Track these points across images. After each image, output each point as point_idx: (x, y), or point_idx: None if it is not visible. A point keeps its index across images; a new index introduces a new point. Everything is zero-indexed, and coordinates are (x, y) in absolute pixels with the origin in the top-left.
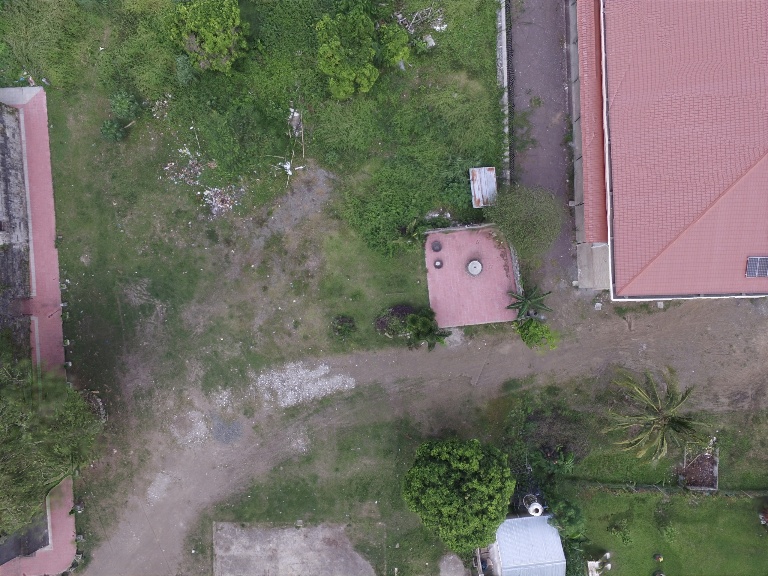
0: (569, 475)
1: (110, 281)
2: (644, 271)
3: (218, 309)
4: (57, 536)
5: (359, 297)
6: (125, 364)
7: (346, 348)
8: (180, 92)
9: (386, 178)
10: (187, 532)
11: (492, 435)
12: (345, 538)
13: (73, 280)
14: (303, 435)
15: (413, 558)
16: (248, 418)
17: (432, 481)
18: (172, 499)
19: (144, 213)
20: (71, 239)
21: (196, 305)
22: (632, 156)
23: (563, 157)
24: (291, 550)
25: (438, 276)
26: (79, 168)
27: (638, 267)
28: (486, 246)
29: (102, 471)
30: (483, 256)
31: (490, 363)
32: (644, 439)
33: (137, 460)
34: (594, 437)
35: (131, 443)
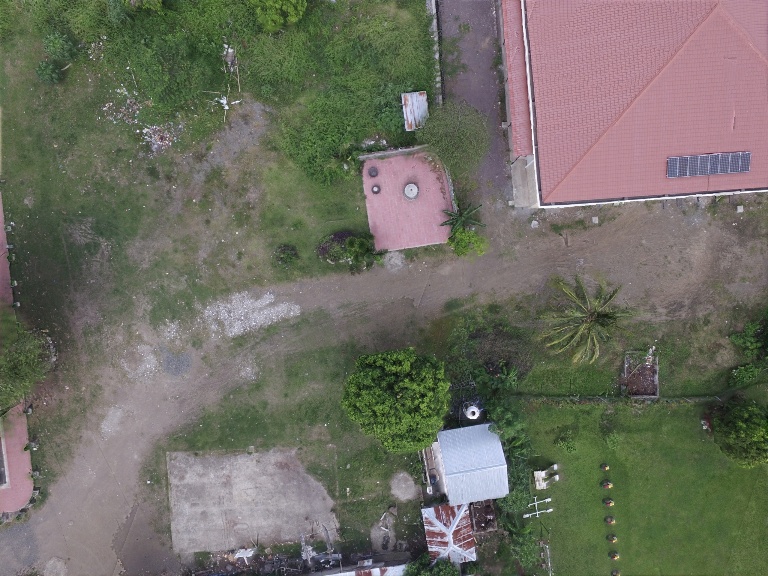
0: (514, 391)
1: (54, 222)
2: (568, 176)
3: (162, 244)
4: (14, 474)
5: (300, 226)
6: (73, 302)
7: (290, 276)
8: (115, 33)
9: (320, 107)
10: (142, 464)
11: (436, 354)
12: (297, 461)
13: (18, 222)
14: (251, 363)
15: (364, 477)
16: (197, 349)
17: (365, 384)
18: (125, 432)
19: (85, 153)
20: (14, 182)
21: (140, 241)
22: (554, 68)
23: (494, 80)
24: (244, 476)
25: (377, 202)
26: (19, 112)
27: (562, 173)
28: (422, 170)
29: (55, 408)
30: (420, 180)
31: (431, 284)
32: (575, 339)
33: (89, 396)
34: (536, 352)
35: (82, 379)
